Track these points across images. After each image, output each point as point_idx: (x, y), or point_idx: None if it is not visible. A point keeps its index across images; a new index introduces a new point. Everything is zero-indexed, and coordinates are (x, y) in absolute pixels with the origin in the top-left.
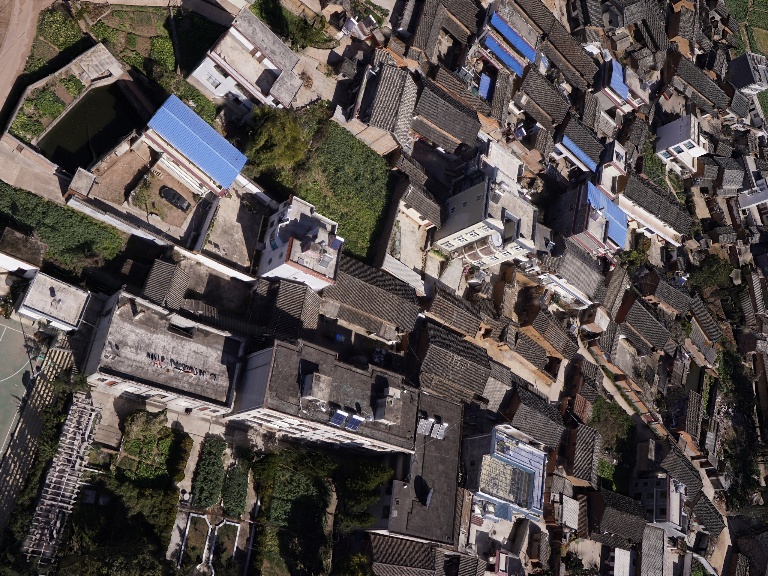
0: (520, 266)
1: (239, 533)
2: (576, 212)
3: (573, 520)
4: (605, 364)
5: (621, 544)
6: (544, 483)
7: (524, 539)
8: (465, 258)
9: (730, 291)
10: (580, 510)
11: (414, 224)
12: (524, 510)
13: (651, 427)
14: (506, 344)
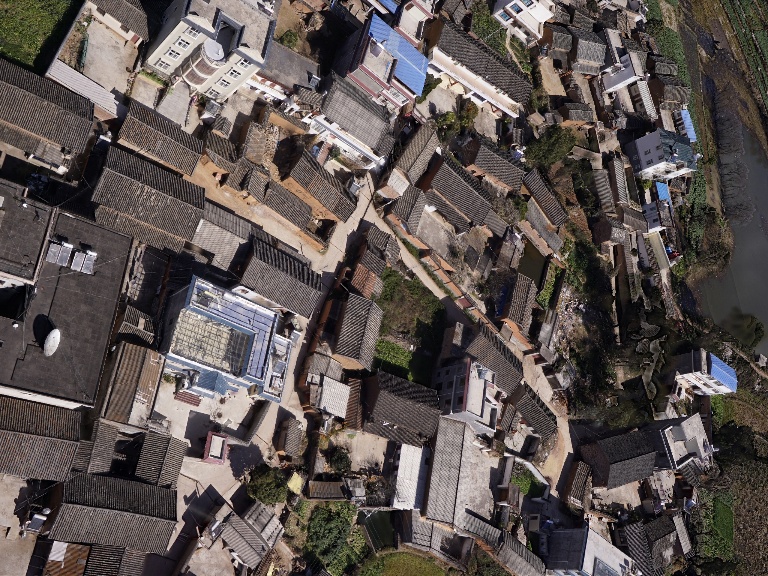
0: (280, 107)
1: None
2: (357, 49)
3: (339, 407)
4: (406, 237)
5: (409, 439)
6: (269, 348)
7: (259, 423)
8: (186, 82)
9: (586, 176)
10: (351, 396)
11: (118, 39)
12: (243, 381)
13: (469, 314)
14: (249, 193)
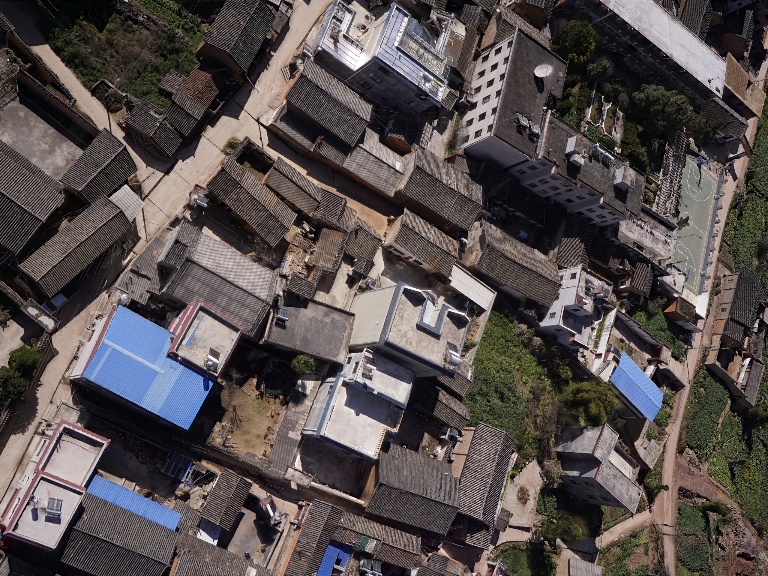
0: None
1: (587, 116)
2: None
3: None
4: None
5: None
6: None
7: None
8: None
9: None
10: None
11: None
12: None
13: None
14: None
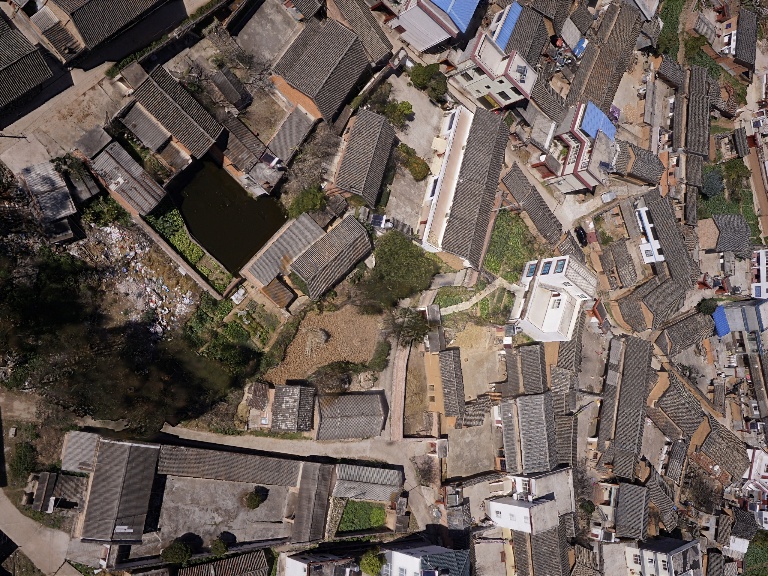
0: None
1: None
2: None
3: None
4: None
5: None
6: None
7: None
8: None
9: None
10: None
11: None
12: None
13: None
14: None
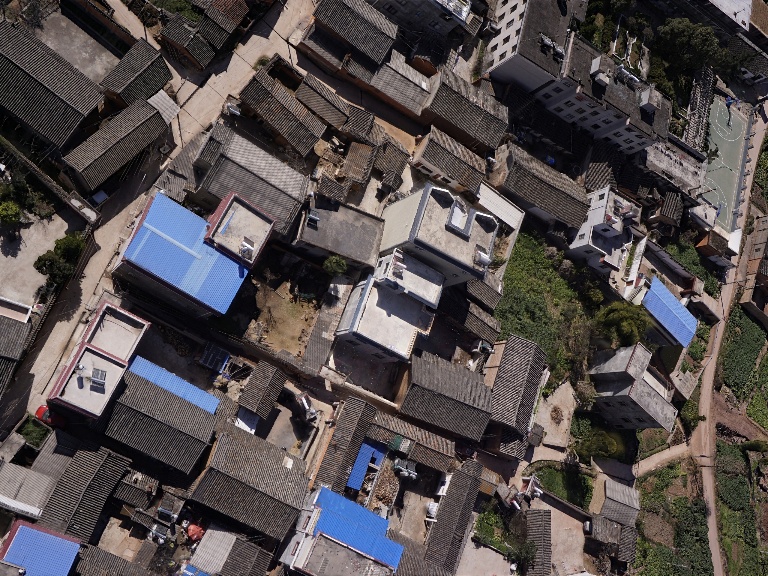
0: None
1: (612, 50)
2: None
3: None
4: None
5: None
6: None
7: None
8: None
9: None
10: None
11: None
12: None
13: None
14: None
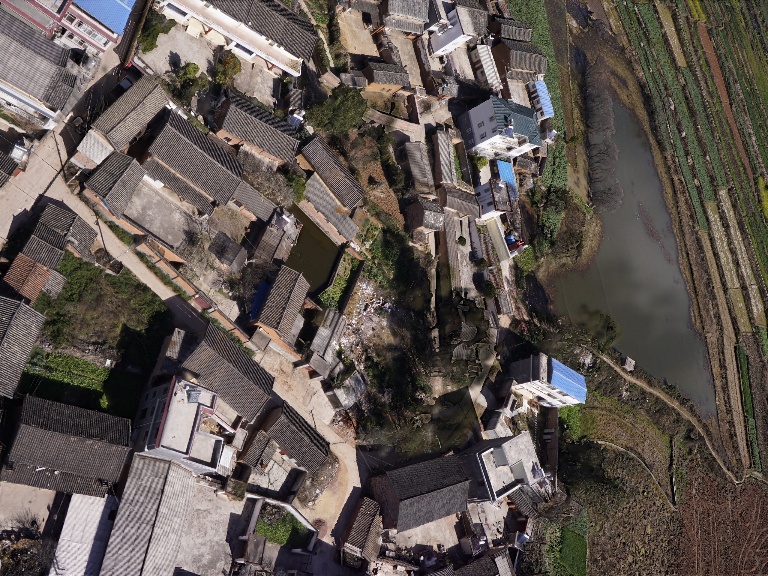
0: None
1: None
2: None
3: None
4: (112, 219)
5: (82, 487)
6: None
7: None
8: None
9: (400, 151)
10: None
11: None
12: None
13: (210, 317)
14: None
